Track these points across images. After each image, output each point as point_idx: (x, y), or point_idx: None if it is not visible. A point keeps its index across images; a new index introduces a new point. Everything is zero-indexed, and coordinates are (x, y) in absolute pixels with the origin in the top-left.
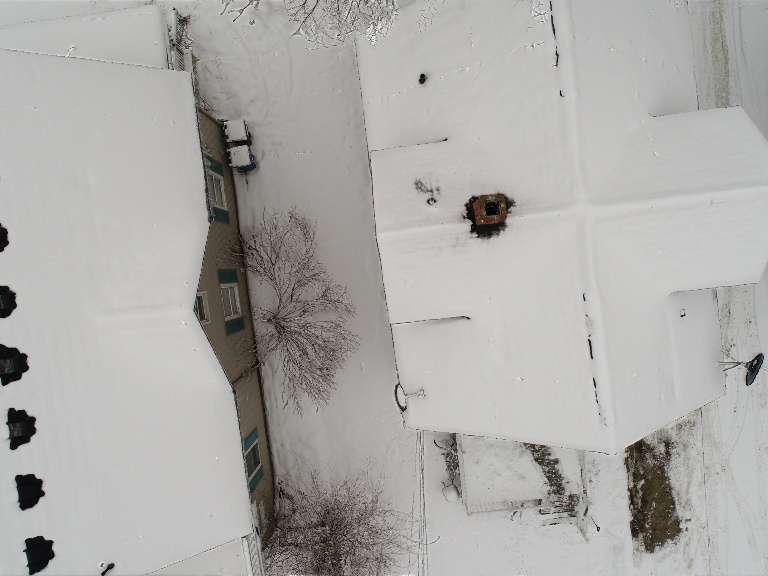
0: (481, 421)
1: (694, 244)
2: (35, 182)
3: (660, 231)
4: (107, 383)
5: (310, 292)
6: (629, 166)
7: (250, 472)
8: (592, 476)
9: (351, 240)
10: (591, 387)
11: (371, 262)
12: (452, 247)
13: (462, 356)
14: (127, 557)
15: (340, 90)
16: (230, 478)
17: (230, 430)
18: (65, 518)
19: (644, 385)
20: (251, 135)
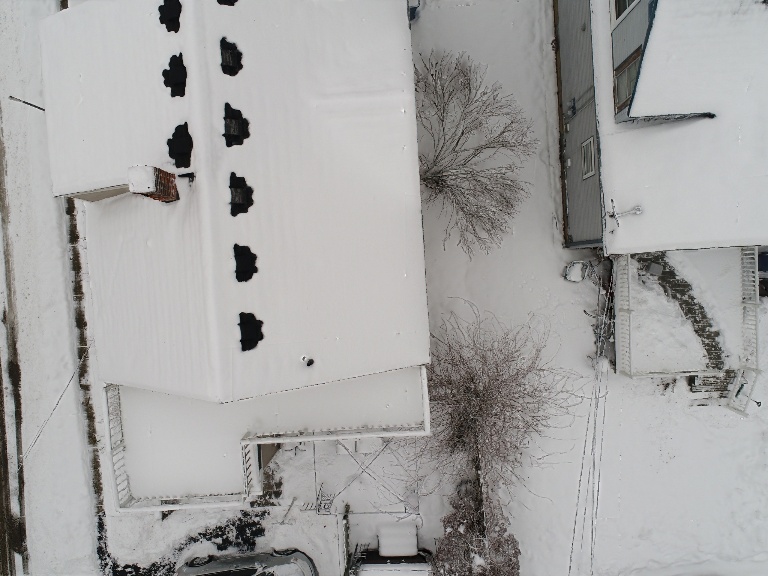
0: (717, 228)
1: None
2: None
3: None
4: (316, 171)
5: (477, 139)
6: None
7: None
8: (748, 355)
9: None
10: None
11: None
12: (732, 14)
13: (698, 161)
14: (325, 356)
15: None
16: (415, 299)
17: (417, 250)
18: (274, 300)
19: None
20: None
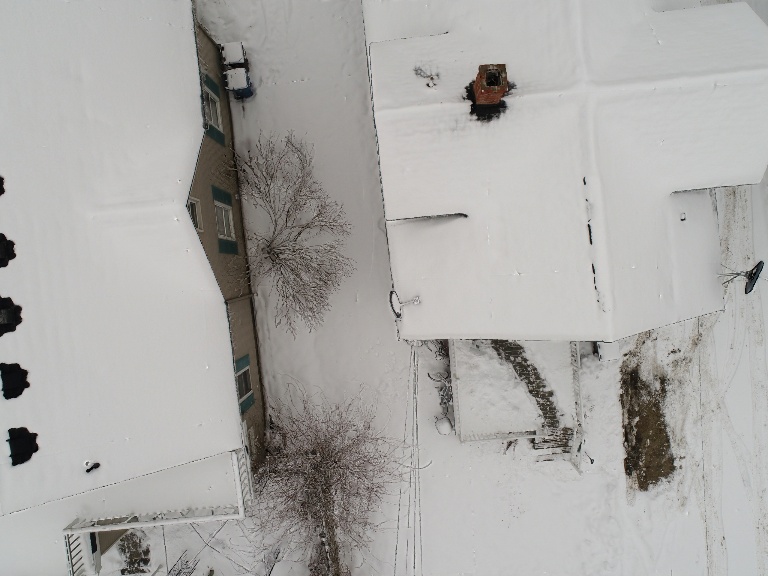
0: (477, 322)
1: (696, 134)
2: (26, 67)
3: (662, 118)
4: (96, 280)
5: (305, 216)
6: (632, 53)
7: (241, 394)
8: (587, 411)
9: (348, 169)
10: (590, 273)
11: (368, 192)
12: (451, 131)
13: (459, 257)
14: (113, 458)
15: (340, 17)
16: (220, 389)
17: (221, 341)
18: (50, 412)
19: (643, 279)
20: (249, 62)
